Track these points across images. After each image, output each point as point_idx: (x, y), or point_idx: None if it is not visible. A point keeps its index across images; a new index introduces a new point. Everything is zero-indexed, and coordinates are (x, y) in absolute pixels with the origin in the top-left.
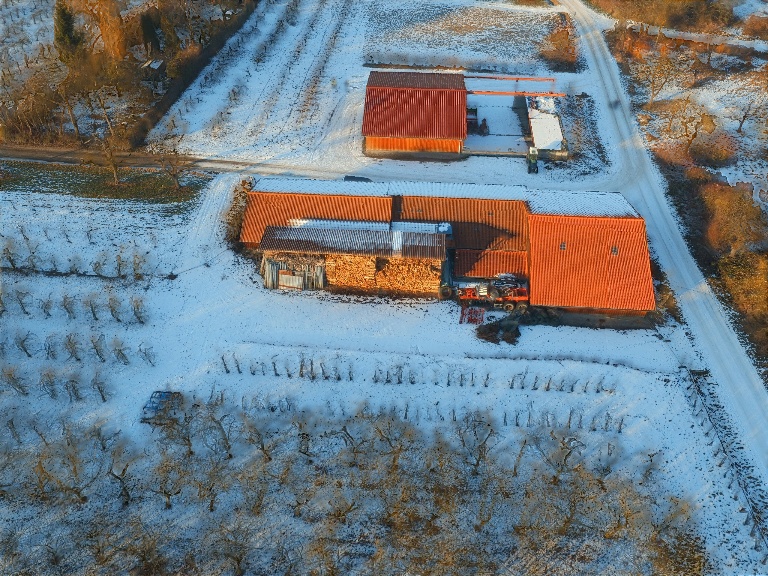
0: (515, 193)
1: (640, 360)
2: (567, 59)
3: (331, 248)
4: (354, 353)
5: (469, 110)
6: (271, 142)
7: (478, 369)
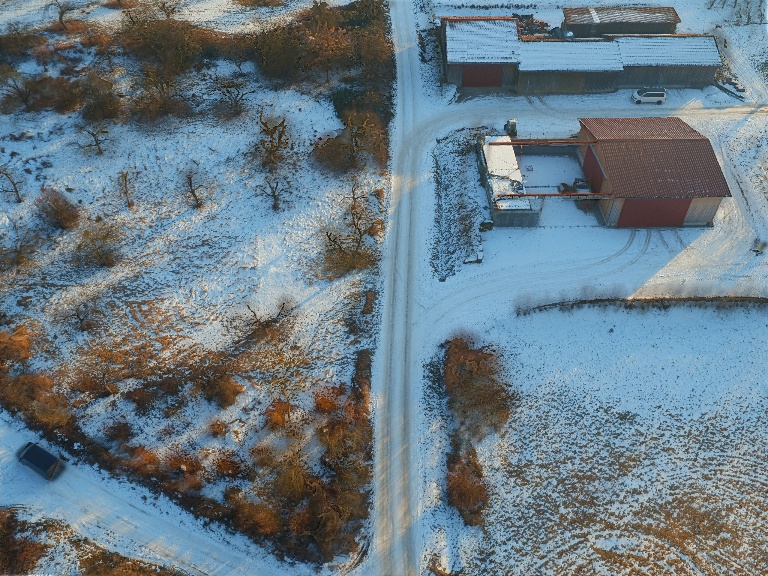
0: (527, 55)
1: (448, 15)
2: (466, 342)
3: (632, 9)
4: (592, 4)
5: (590, 201)
6: (766, 137)
7: (530, 2)
